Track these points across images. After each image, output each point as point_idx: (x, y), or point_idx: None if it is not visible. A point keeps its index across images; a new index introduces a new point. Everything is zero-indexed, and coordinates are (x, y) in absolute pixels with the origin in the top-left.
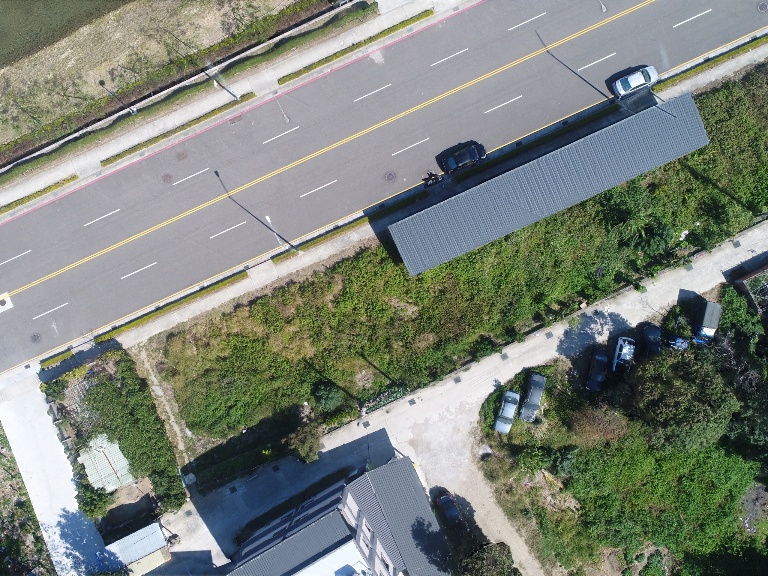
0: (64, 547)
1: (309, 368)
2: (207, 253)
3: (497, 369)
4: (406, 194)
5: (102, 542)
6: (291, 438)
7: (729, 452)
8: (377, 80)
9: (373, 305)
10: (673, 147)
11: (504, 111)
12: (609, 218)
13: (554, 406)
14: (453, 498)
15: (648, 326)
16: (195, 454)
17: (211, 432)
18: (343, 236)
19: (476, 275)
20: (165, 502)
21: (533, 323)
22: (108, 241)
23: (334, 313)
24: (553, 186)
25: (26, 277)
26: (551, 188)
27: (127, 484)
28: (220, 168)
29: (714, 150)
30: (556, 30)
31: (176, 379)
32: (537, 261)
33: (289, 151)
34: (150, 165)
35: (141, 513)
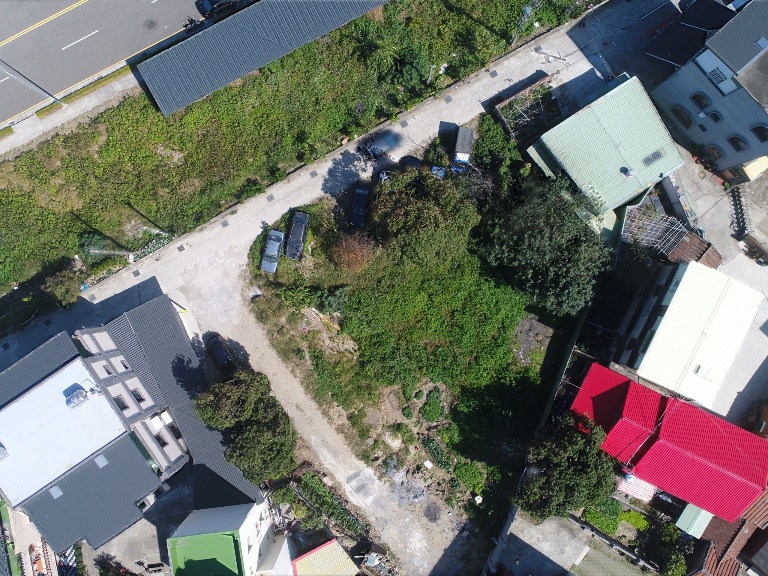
0: None
1: (75, 219)
2: None
3: (264, 211)
4: (168, 42)
5: None
6: (48, 282)
7: (498, 283)
8: None
9: (136, 152)
10: None
11: None
12: (367, 54)
13: (320, 244)
14: (224, 341)
15: (408, 158)
16: None
17: None
18: (107, 87)
19: (236, 116)
20: None
21: (298, 163)
22: None
23: (100, 164)
24: (300, 17)
25: None
26: (298, 19)
27: None
28: None
29: None
30: None
31: None
32: (298, 100)
33: (48, 3)
34: None
35: None
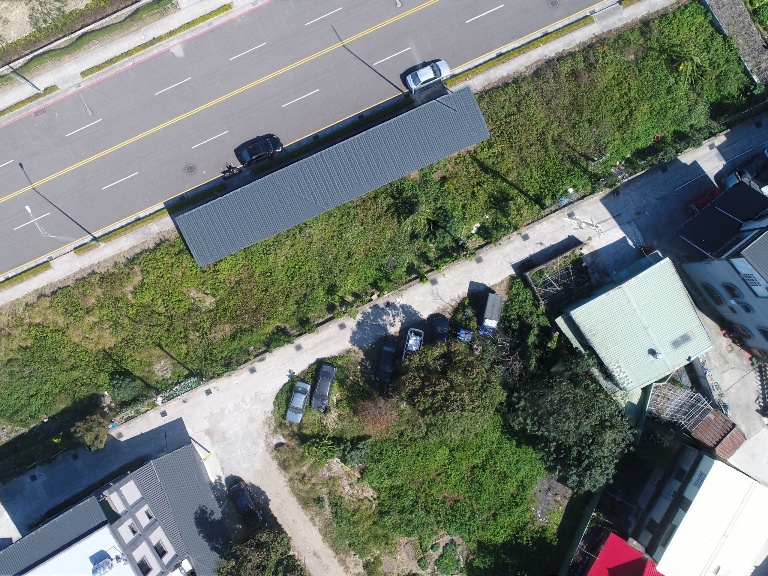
0: None
1: (107, 358)
2: (11, 244)
3: (291, 360)
4: (206, 186)
5: None
6: (78, 426)
7: (520, 443)
8: (177, 74)
9: (169, 296)
10: (454, 140)
11: (301, 105)
12: (401, 211)
13: (345, 396)
14: (246, 487)
15: (437, 318)
16: None
17: (11, 421)
18: (144, 228)
19: (269, 267)
20: None
21: (327, 314)
22: None
23: (133, 304)
24: (337, 179)
25: None
26: (335, 181)
27: None
28: (24, 160)
29: (503, 144)
30: (352, 25)
31: None
32: (331, 253)
33: (91, 143)
34: None
35: None
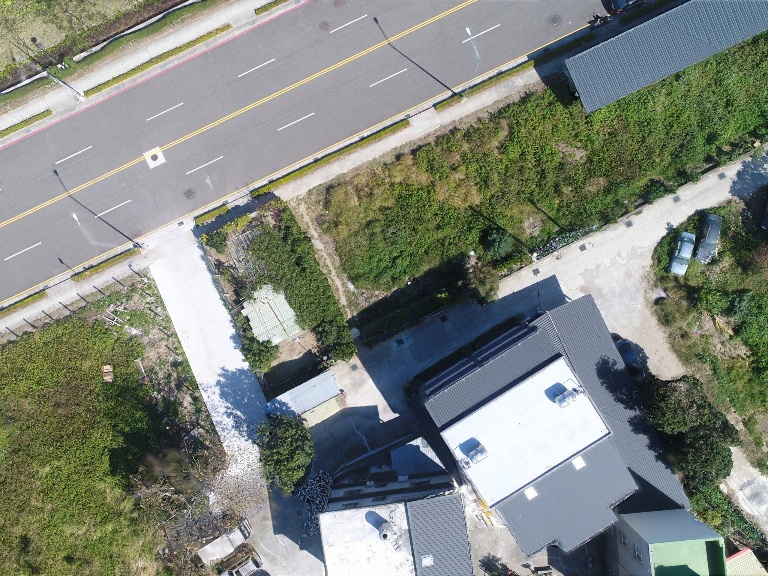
0: (224, 406)
1: (477, 215)
2: (367, 102)
3: (669, 212)
4: (571, 37)
5: (264, 400)
6: (470, 278)
7: None
8: None
9: (542, 149)
10: None
11: None
12: None
13: (729, 247)
14: None
15: None
16: (358, 308)
17: (377, 283)
18: (507, 81)
19: (648, 115)
20: (337, 350)
21: (705, 165)
22: (264, 92)
23: (500, 159)
24: (732, 17)
25: (178, 131)
26: (730, 19)
27: (291, 338)
28: (379, 14)
29: None
30: None
31: (340, 229)
32: (708, 101)
33: None
34: (306, 13)
35: (304, 370)
